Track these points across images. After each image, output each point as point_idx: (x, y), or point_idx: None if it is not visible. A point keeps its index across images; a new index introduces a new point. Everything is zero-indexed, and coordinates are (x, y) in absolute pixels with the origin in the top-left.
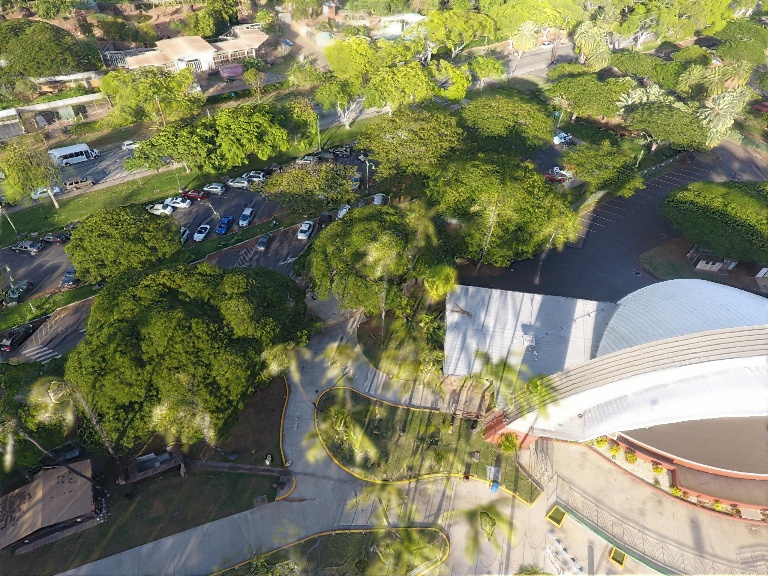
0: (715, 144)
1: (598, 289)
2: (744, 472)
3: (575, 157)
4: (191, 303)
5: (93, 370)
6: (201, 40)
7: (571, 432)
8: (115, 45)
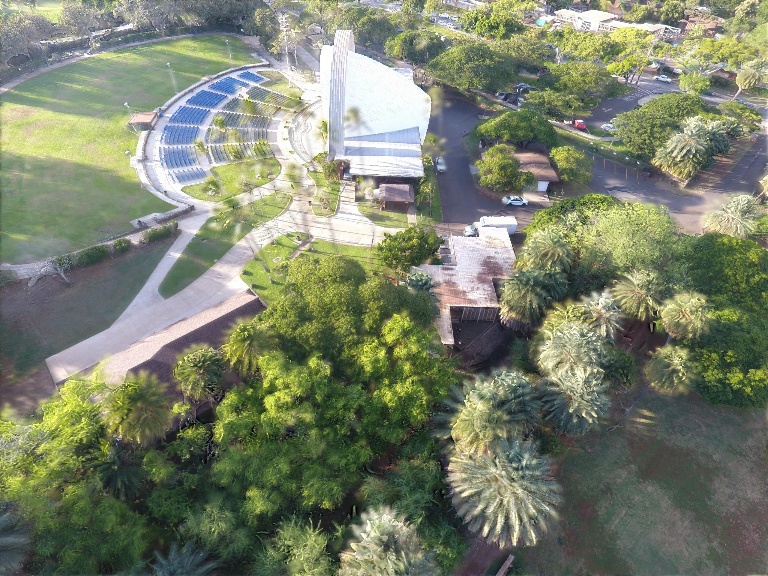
0: (672, 172)
1: None
2: None
3: None
4: (364, 13)
5: (340, 12)
6: (611, 16)
7: None
8: (587, 9)
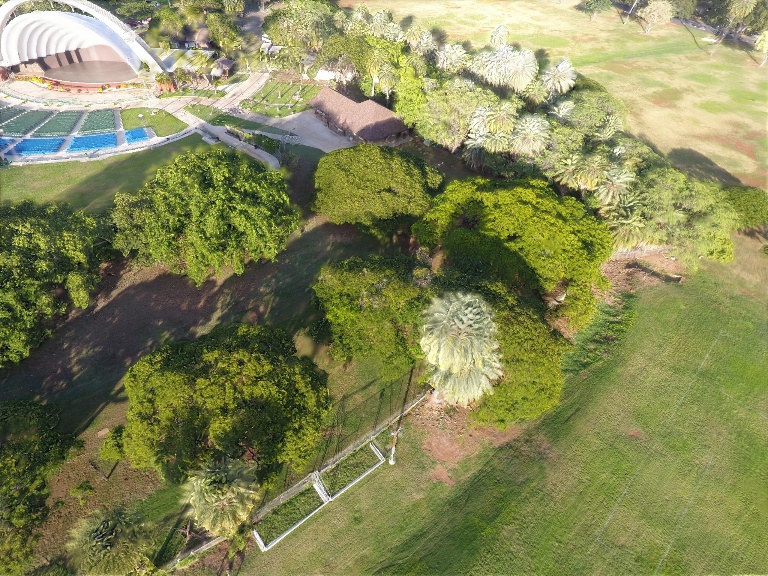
0: (237, 10)
1: None
2: (82, 82)
3: (125, 5)
4: None
5: None
6: None
7: (4, 63)
8: None
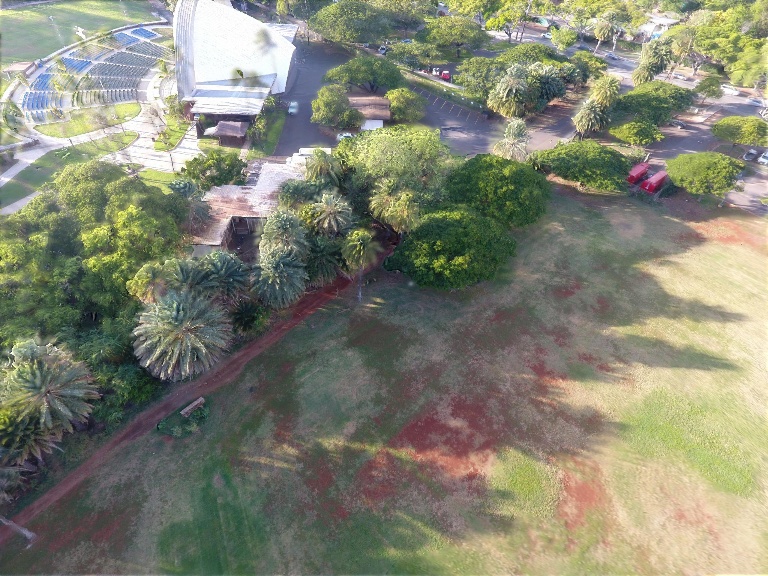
0: (501, 112)
1: (318, 70)
2: None
3: None
4: None
5: None
6: None
7: None
8: None
